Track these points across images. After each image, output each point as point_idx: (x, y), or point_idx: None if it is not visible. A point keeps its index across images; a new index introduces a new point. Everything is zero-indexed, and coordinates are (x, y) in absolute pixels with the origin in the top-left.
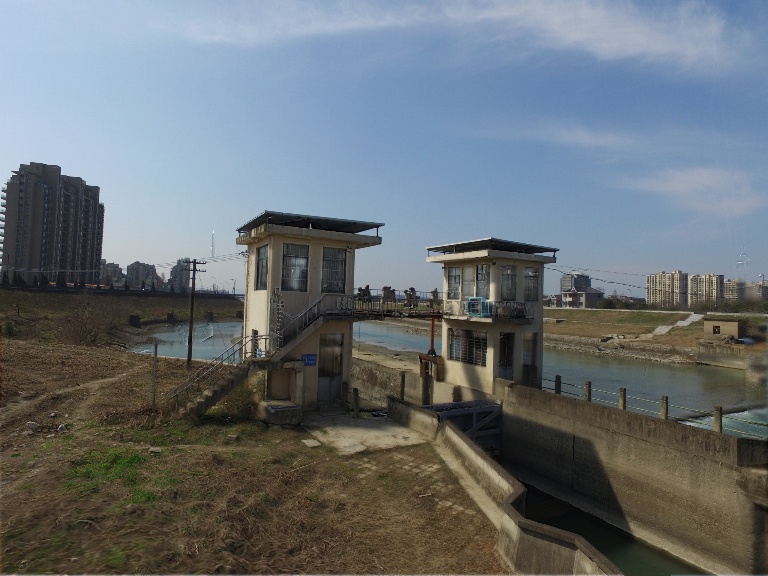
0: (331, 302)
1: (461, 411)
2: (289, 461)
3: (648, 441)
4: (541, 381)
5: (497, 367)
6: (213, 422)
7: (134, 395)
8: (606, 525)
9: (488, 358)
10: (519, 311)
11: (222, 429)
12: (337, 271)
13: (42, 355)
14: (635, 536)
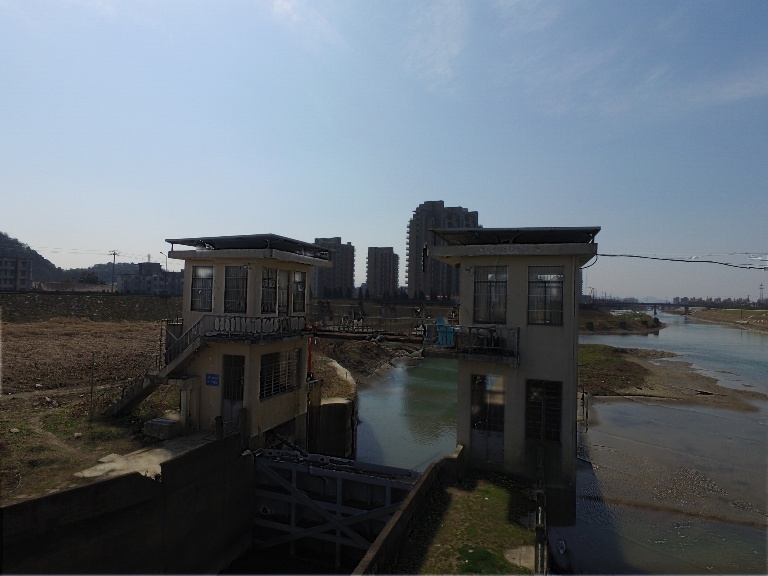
0: (209, 323)
1: (365, 478)
2: (46, 466)
3: None
4: (574, 471)
5: (465, 428)
6: (115, 421)
7: (160, 391)
8: None
9: None
10: (481, 342)
11: (96, 428)
12: (239, 290)
13: None
14: None
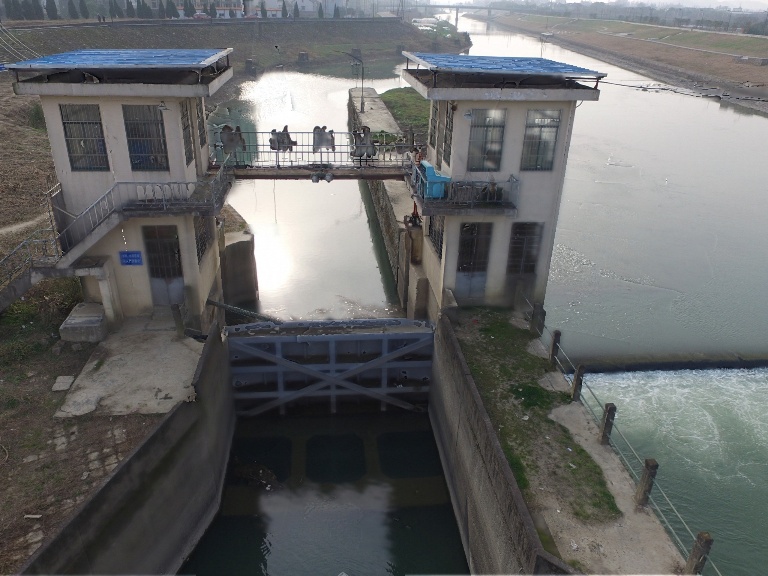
0: (128, 193)
1: (361, 336)
2: None
3: (491, 482)
4: None
5: (452, 273)
6: None
7: None
8: (460, 542)
9: (442, 257)
10: (484, 196)
11: None
12: (152, 139)
13: (13, 170)
14: (471, 575)
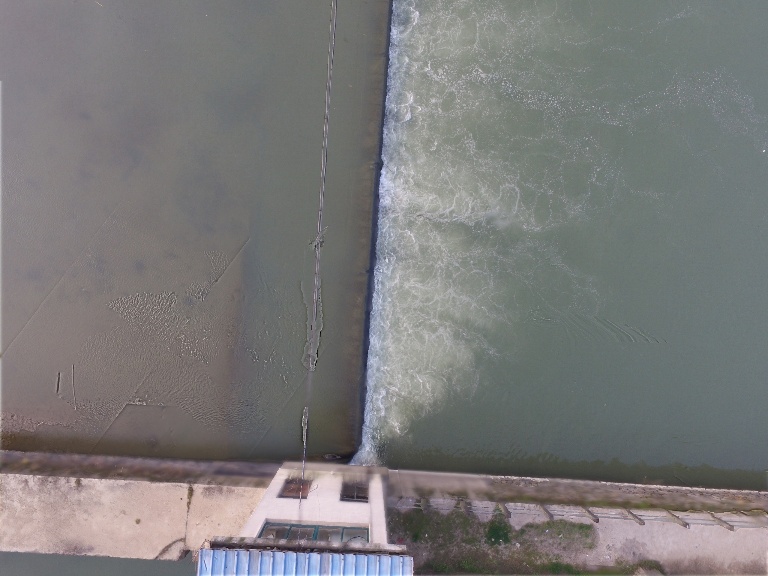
0: None
1: None
2: None
3: None
4: None
5: None
6: None
7: None
8: None
9: None
10: None
11: None
12: None
13: None
14: None
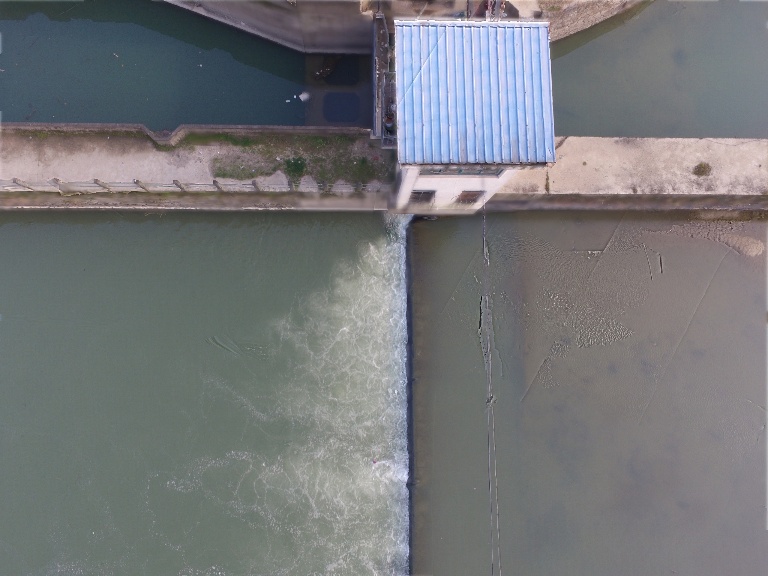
0: None
1: None
2: None
3: None
4: None
5: None
6: None
7: None
8: None
9: None
10: None
11: None
12: None
13: None
14: None
